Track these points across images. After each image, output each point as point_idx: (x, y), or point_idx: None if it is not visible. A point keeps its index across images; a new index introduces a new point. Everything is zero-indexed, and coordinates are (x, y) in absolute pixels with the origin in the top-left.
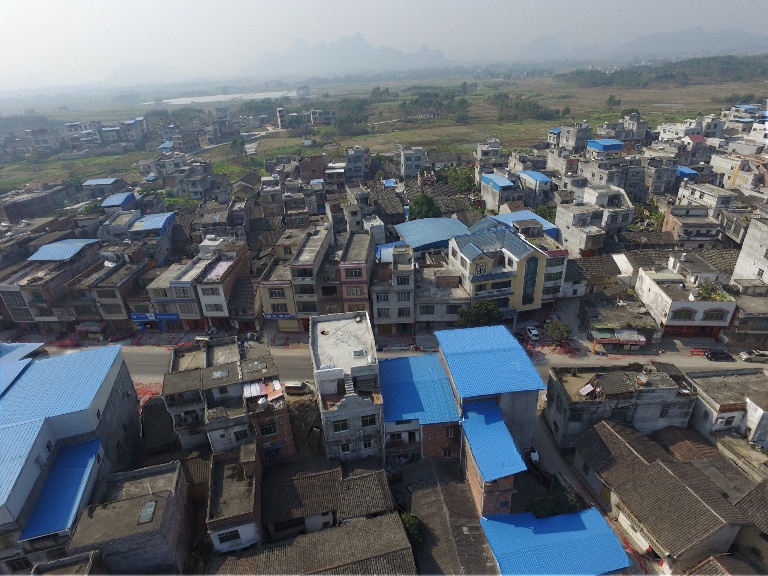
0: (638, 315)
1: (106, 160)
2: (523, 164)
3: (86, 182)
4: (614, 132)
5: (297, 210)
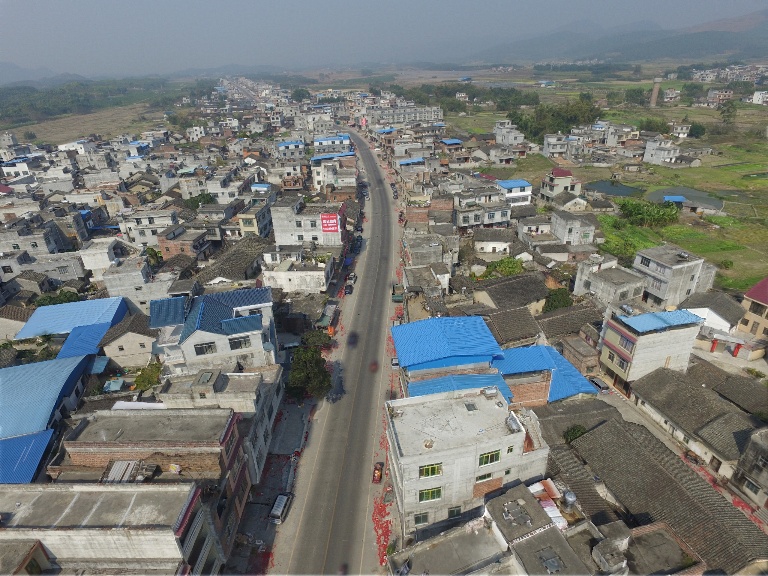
0: (309, 297)
1: None
2: None
3: None
4: None
5: None
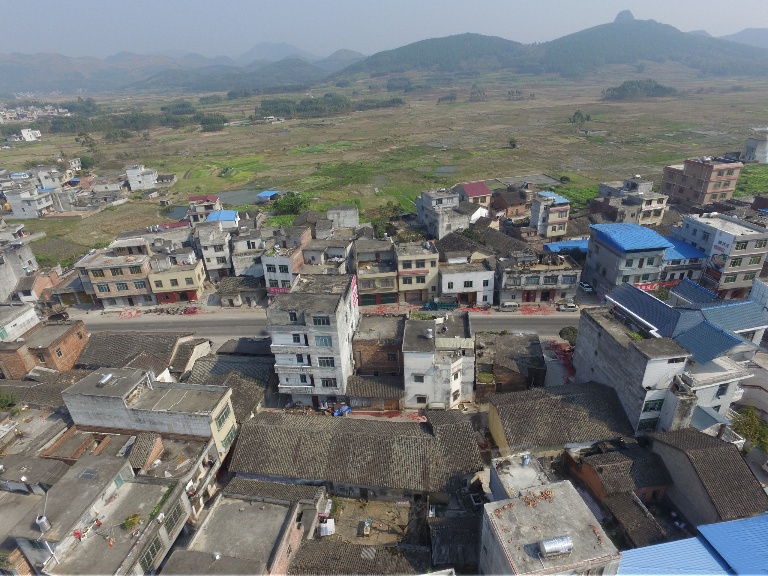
0: (488, 345)
1: None
2: None
3: None
4: None
5: None
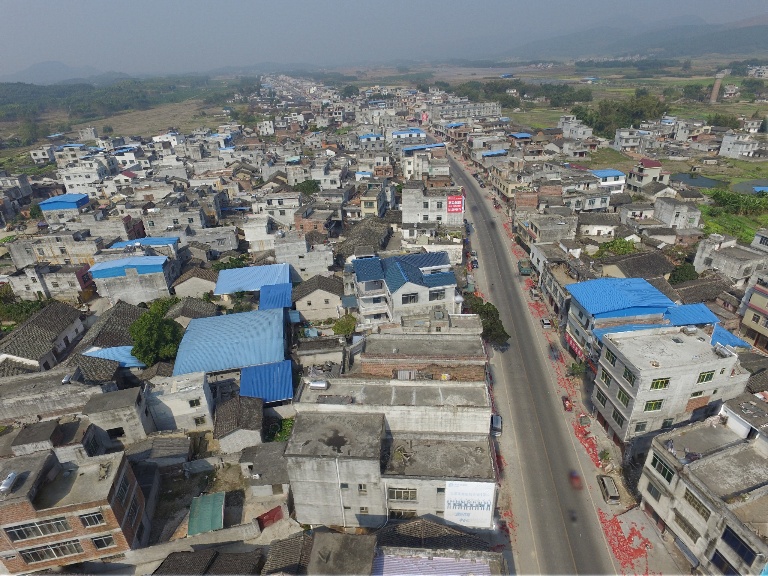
0: None
1: None
2: (94, 241)
3: None
4: (3, 194)
5: (69, 485)
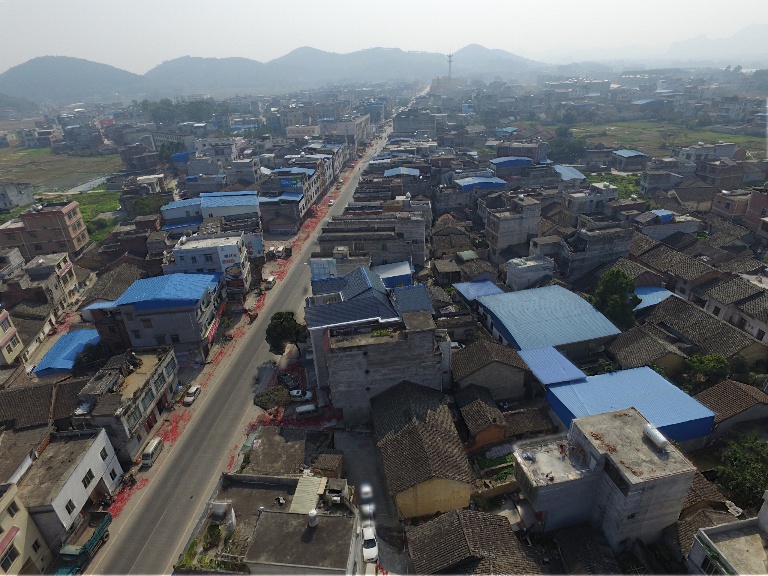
0: None
1: (738, 140)
2: None
3: (619, 150)
4: None
5: (512, 214)
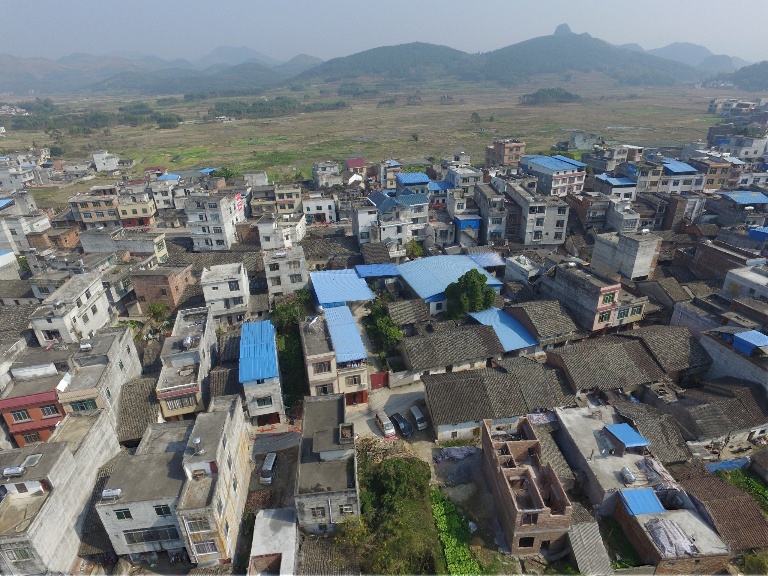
0: None
1: None
2: None
3: None
4: None
5: None
